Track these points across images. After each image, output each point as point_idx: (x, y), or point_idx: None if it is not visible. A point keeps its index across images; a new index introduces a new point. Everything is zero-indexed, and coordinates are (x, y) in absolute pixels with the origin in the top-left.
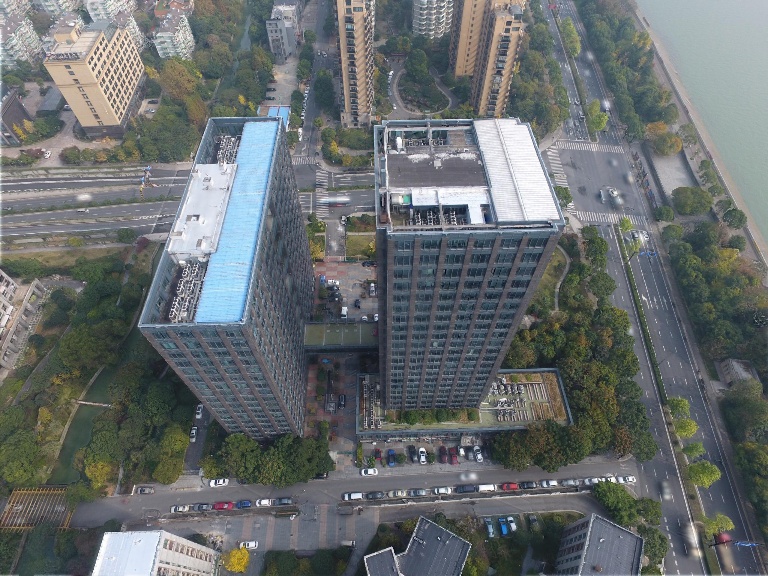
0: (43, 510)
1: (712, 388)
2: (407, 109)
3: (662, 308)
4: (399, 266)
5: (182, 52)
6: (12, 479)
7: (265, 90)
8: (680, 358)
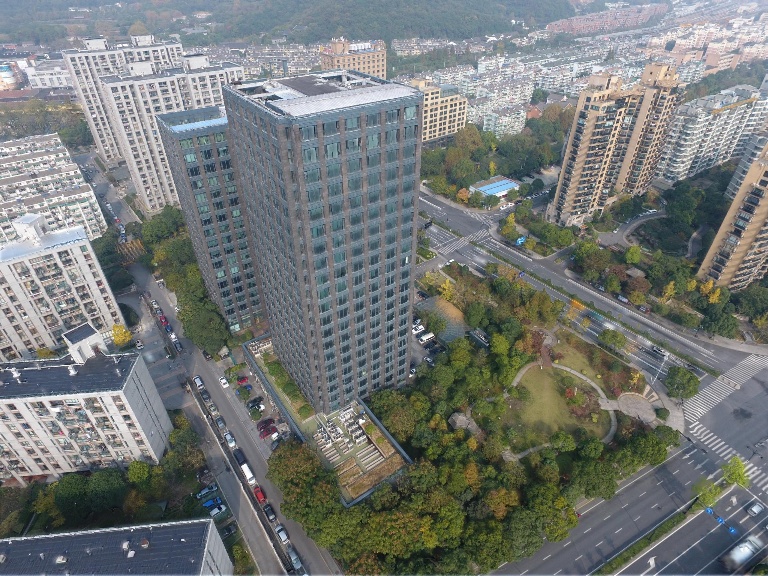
0: (131, 253)
1: None
2: (627, 238)
3: None
4: (233, 129)
5: (499, 132)
6: (143, 233)
7: (524, 174)
8: None
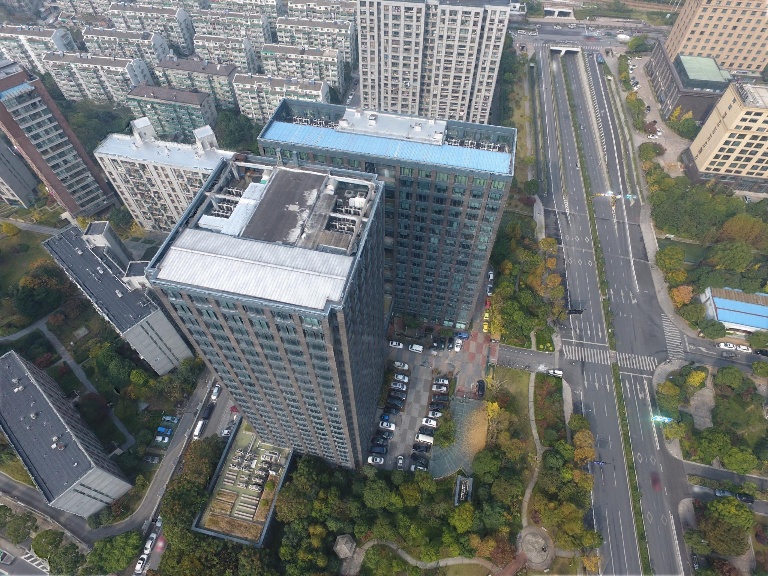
0: None
1: None
2: None
3: None
4: None
5: None
6: None
7: None
8: None
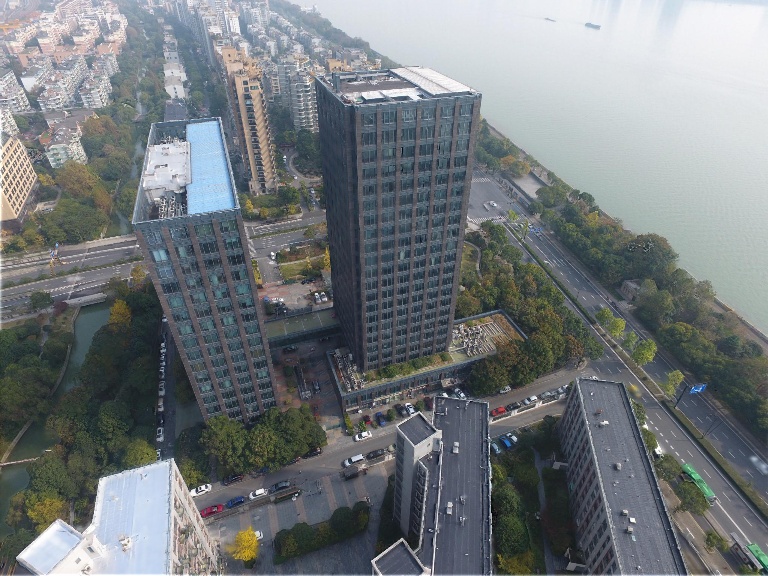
0: None
1: (622, 306)
2: (306, 177)
3: (562, 265)
4: (366, 146)
5: None
6: None
7: None
8: (590, 293)
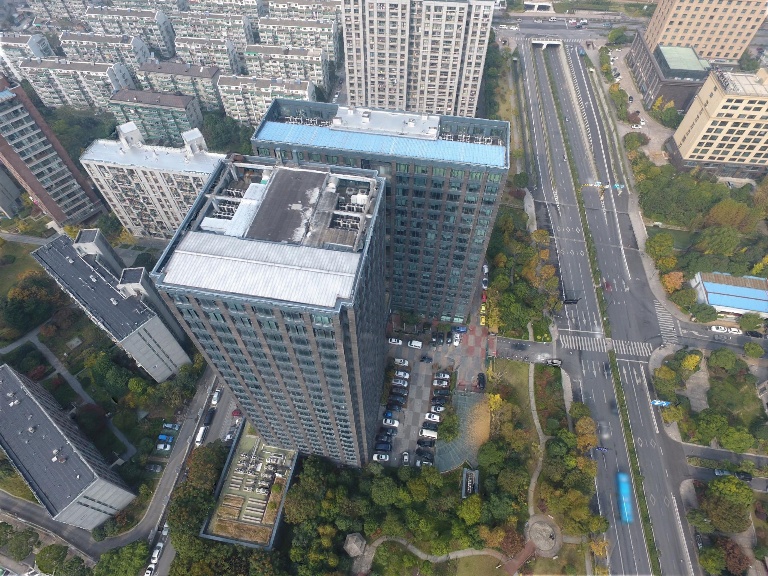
0: None
1: None
2: None
3: None
4: None
5: None
6: None
7: None
8: None
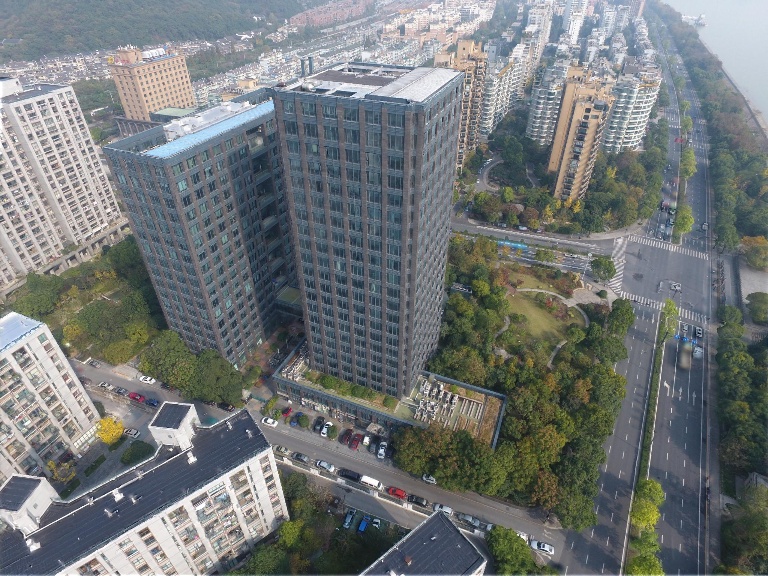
0: None
1: (720, 503)
2: (489, 185)
3: (687, 401)
4: (289, 135)
5: None
6: None
7: None
8: (687, 456)
